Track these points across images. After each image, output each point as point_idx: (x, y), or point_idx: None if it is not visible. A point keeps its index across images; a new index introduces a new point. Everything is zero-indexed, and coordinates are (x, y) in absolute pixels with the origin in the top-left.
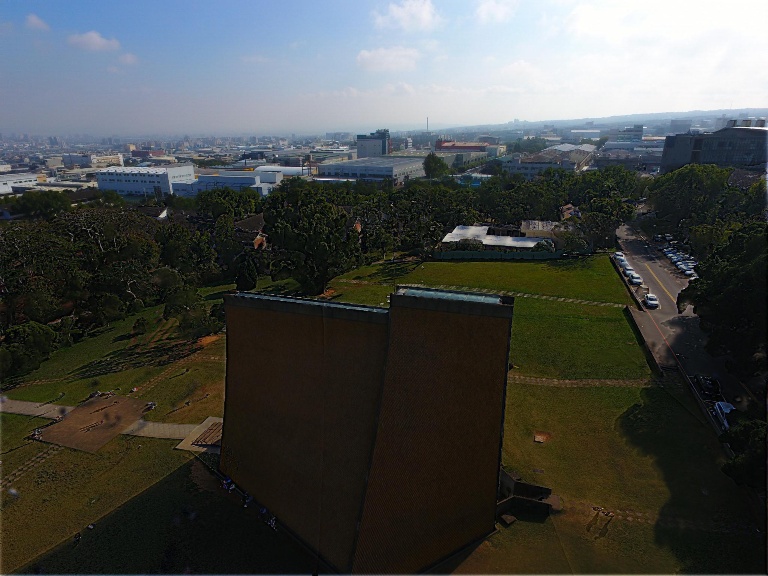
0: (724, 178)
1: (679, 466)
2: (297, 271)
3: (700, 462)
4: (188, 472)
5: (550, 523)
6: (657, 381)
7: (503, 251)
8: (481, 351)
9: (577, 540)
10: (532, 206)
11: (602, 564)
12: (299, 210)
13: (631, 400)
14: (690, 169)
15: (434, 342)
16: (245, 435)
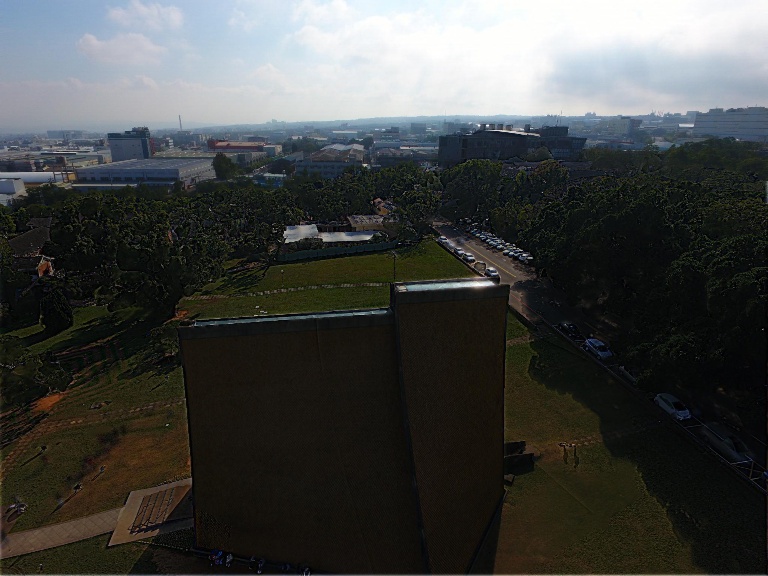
0: (500, 170)
1: (590, 394)
2: (143, 295)
3: (600, 386)
4: (152, 567)
5: (539, 469)
6: (536, 334)
7: (344, 246)
8: (484, 331)
9: (564, 474)
10: (350, 202)
11: (592, 485)
12: (98, 223)
13: (528, 354)
14: (474, 163)
15: (443, 332)
16: (232, 491)
